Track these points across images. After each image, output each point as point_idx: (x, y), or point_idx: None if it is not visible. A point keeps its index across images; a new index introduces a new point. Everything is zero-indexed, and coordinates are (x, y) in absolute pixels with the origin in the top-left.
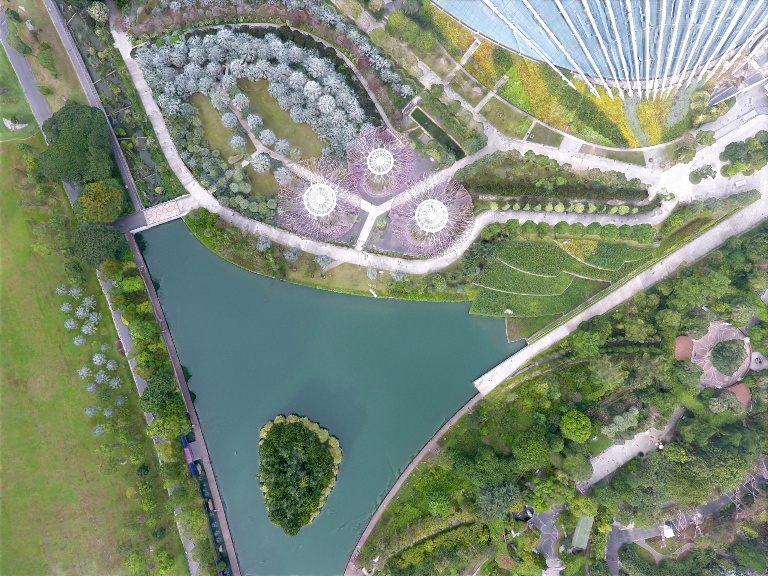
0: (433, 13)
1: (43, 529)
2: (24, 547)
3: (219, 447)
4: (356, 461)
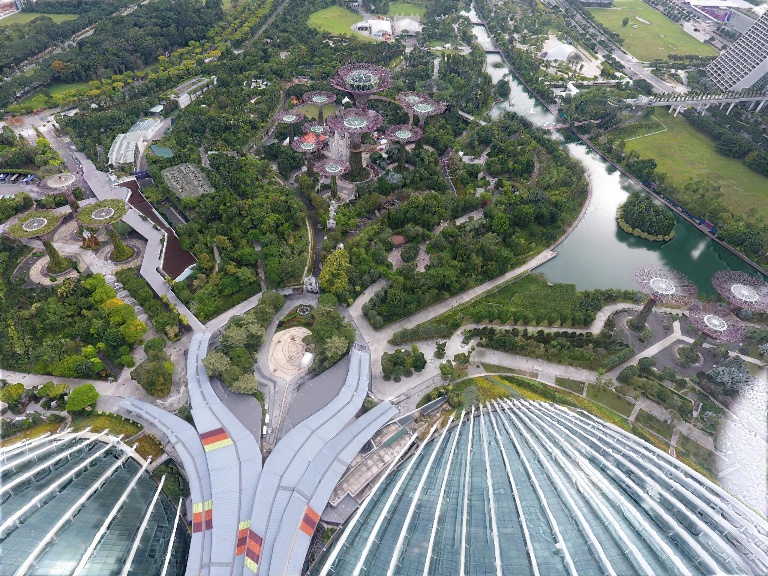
0: (730, 491)
1: (761, 201)
2: (764, 196)
3: (686, 240)
4: None
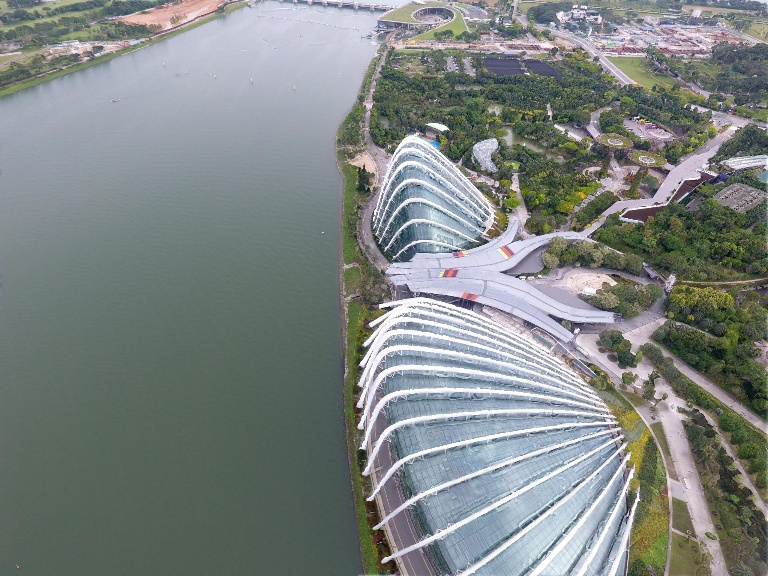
0: None
1: None
2: None
3: None
4: None
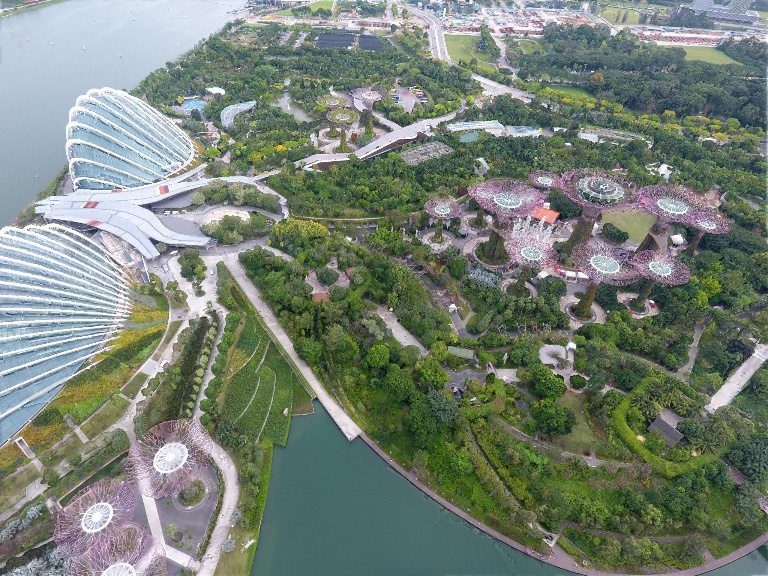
0: None
1: None
2: None
3: None
4: (445, 570)
